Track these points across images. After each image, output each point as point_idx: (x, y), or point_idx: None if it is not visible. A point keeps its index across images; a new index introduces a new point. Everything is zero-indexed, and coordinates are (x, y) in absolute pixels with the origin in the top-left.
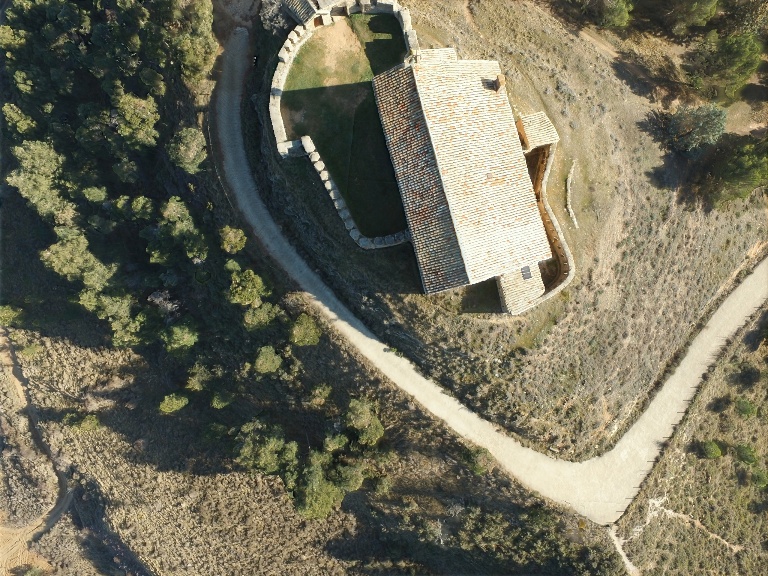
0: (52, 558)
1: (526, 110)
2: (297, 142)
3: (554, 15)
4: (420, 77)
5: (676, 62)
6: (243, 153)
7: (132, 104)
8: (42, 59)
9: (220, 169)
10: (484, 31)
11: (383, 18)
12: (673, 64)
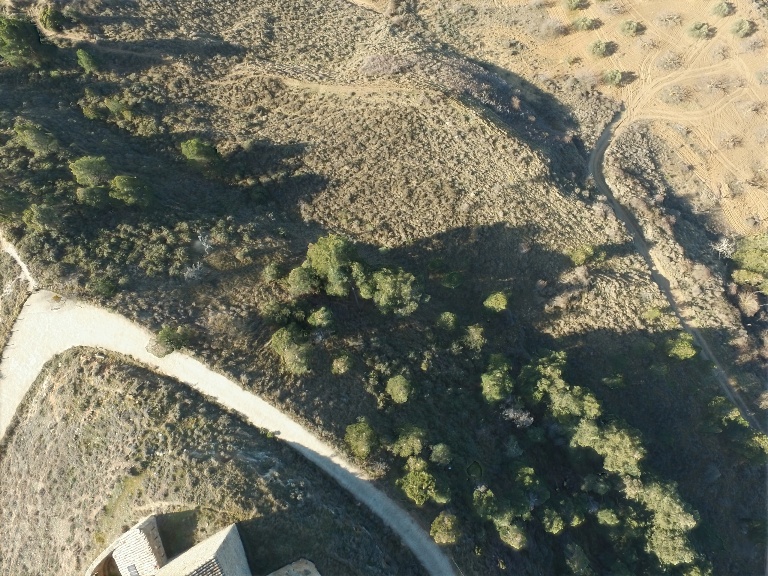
0: (598, 99)
1: None
2: None
3: None
4: None
5: None
6: None
7: None
8: None
9: None
10: None
11: None
12: None
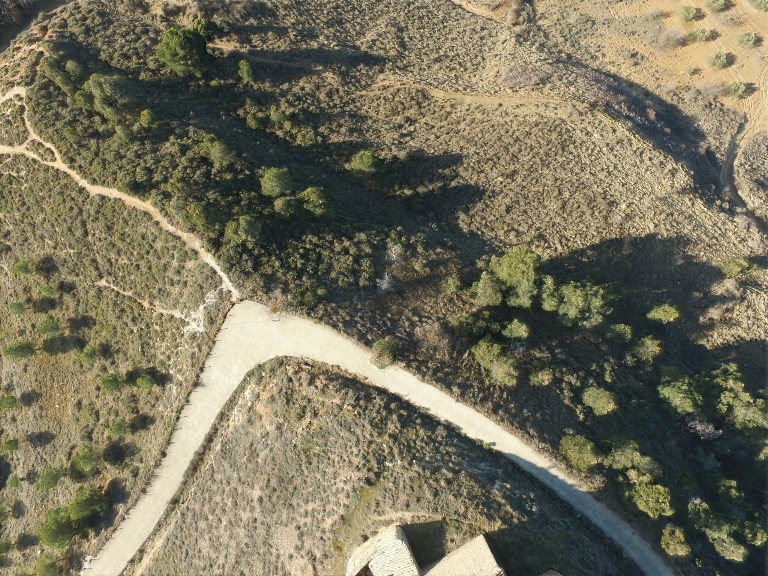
0: (722, 111)
1: None
2: None
3: None
4: None
5: None
6: None
7: None
8: None
9: None
10: None
11: None
12: None
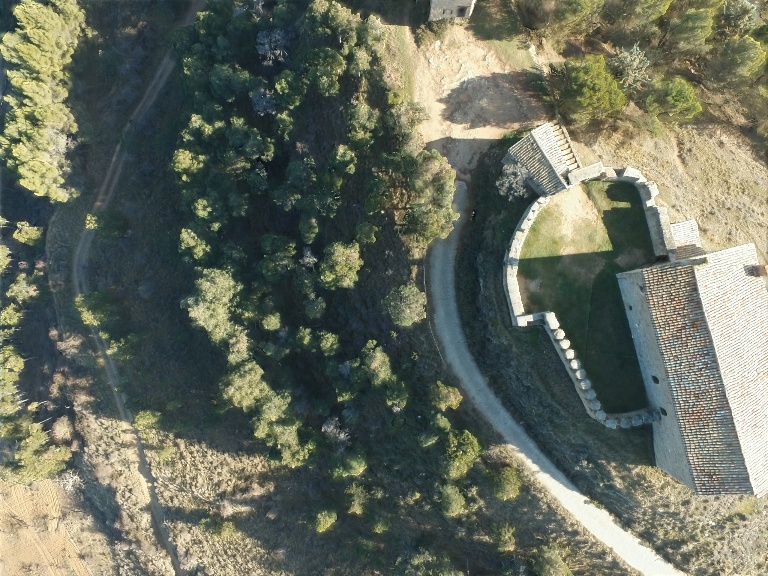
0: None
1: None
2: (538, 316)
3: (755, 158)
4: (699, 275)
5: None
6: (454, 306)
7: (345, 256)
8: (215, 180)
9: (431, 322)
10: (697, 182)
11: (621, 186)
12: None
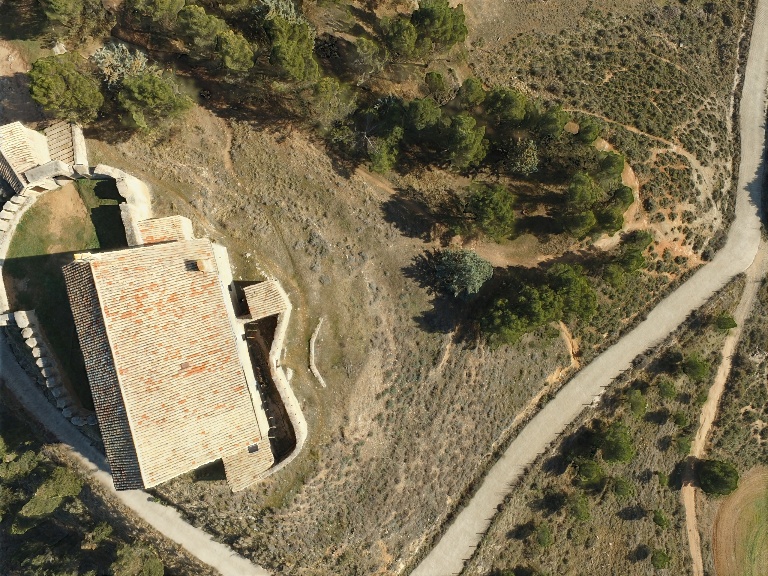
0: None
1: (271, 268)
2: None
3: (329, 152)
4: (101, 272)
5: (461, 195)
6: None
7: None
8: None
9: None
10: (243, 178)
11: (109, 183)
12: (457, 197)
